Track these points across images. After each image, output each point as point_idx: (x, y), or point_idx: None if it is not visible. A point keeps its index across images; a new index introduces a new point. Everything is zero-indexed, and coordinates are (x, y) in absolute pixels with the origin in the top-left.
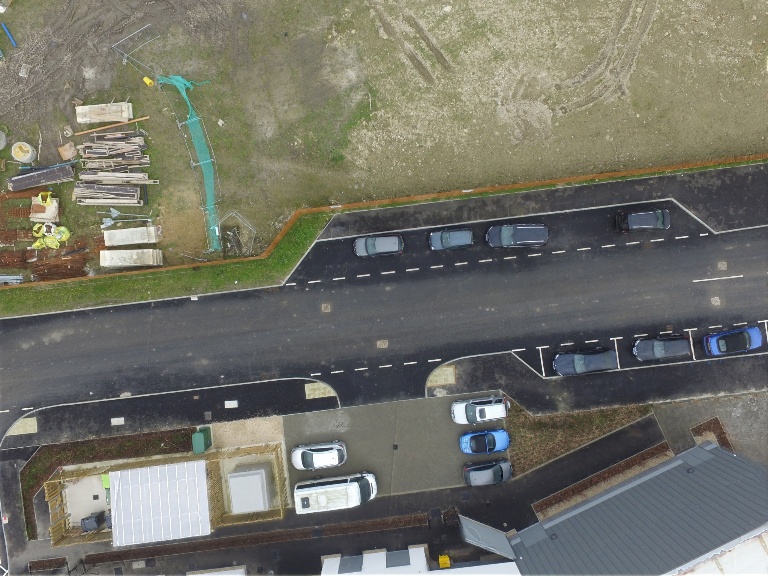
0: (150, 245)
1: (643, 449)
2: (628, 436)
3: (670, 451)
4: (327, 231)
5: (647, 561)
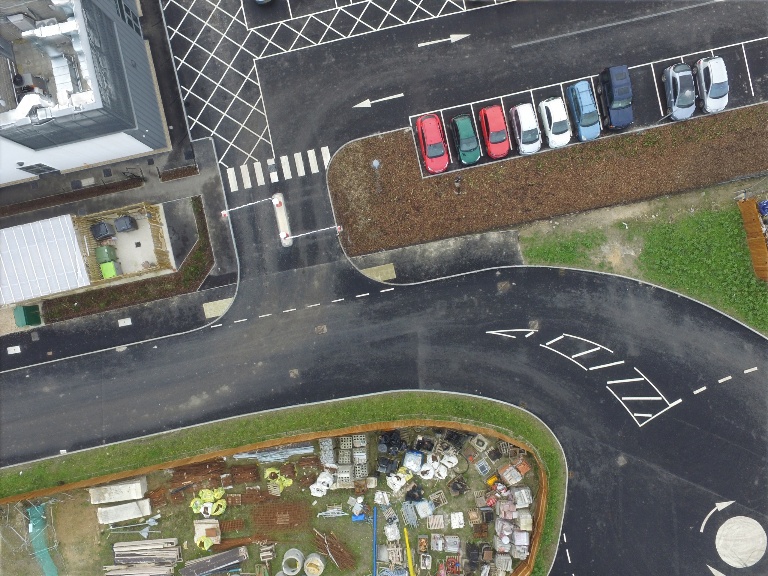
0: (100, 506)
1: None
2: None
3: None
4: None
5: None
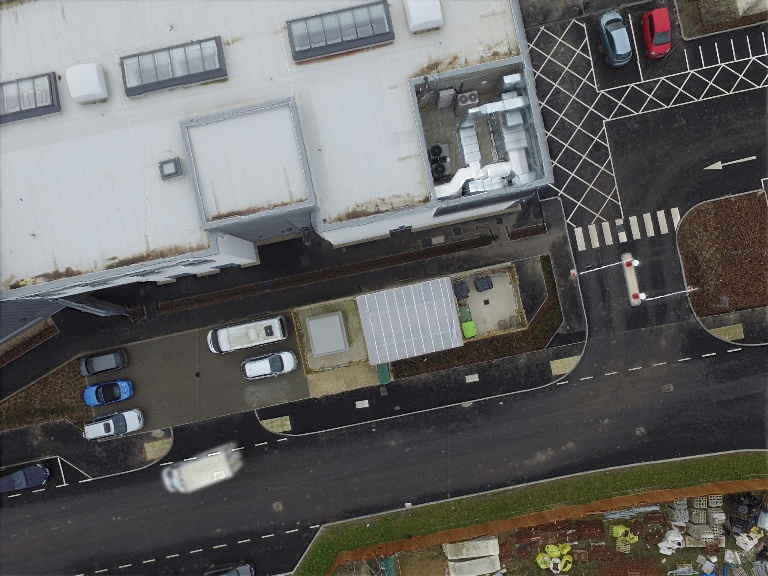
0: (453, 560)
1: None
2: None
3: None
4: None
5: None
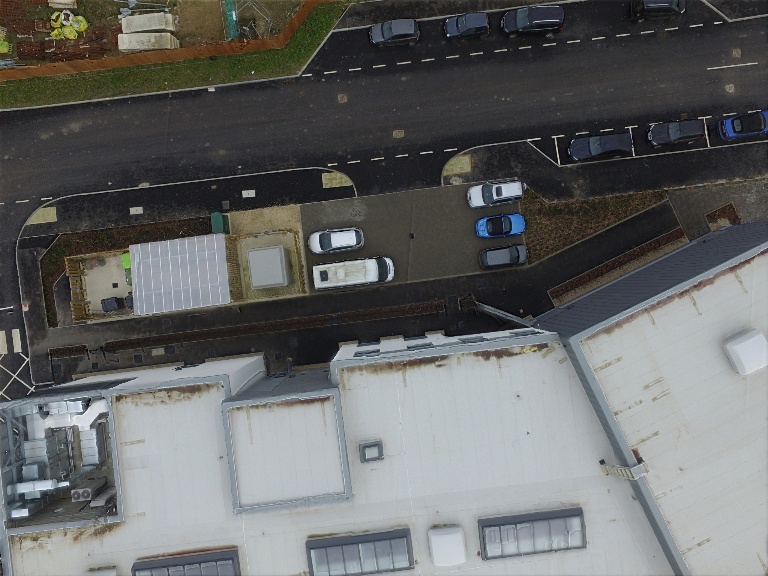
0: (168, 31)
1: (658, 235)
2: (643, 222)
3: (685, 238)
4: (343, 21)
5: (666, 284)
